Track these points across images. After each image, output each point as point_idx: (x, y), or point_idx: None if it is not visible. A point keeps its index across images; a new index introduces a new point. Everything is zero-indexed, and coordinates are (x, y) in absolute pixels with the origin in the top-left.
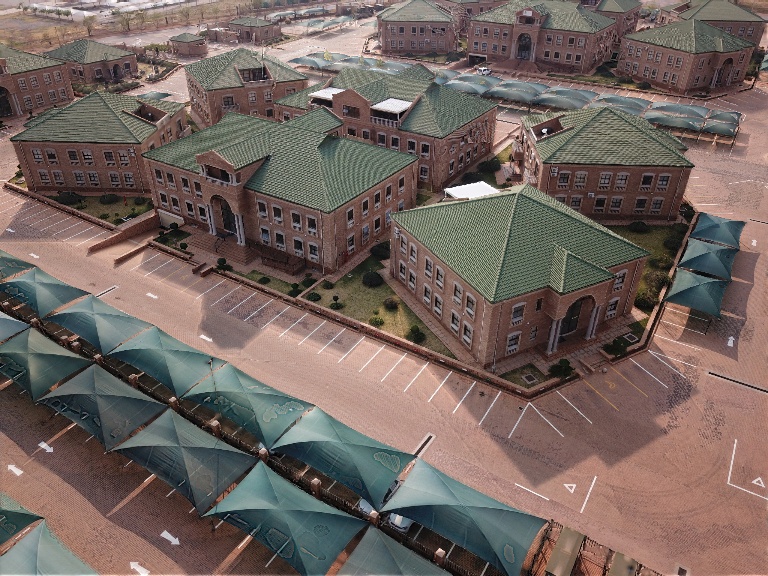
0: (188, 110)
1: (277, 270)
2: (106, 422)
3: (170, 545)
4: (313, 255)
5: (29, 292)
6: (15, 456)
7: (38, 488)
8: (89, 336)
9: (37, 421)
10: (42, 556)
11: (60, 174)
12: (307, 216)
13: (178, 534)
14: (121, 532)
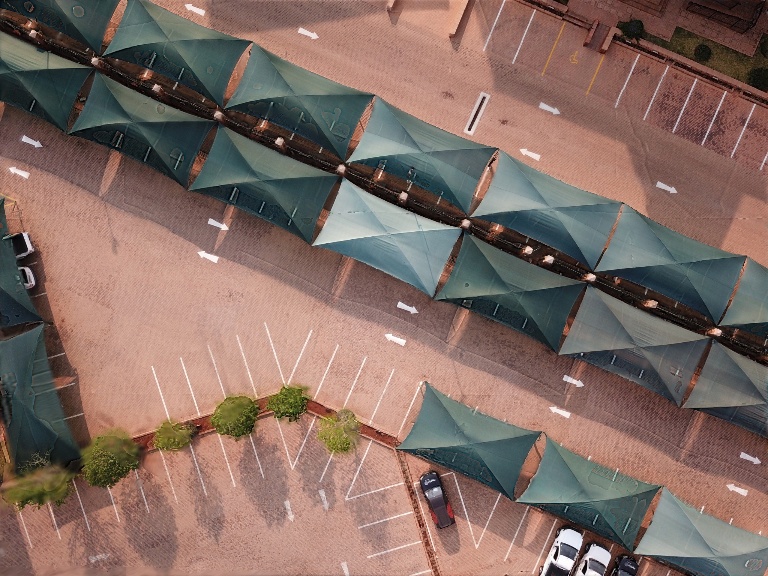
0: None
1: (713, 22)
2: (668, 380)
3: (753, 465)
4: None
5: (427, 174)
6: (549, 397)
7: (598, 429)
8: (562, 246)
9: (541, 350)
10: (705, 534)
11: None
12: None
13: (756, 454)
14: (703, 460)
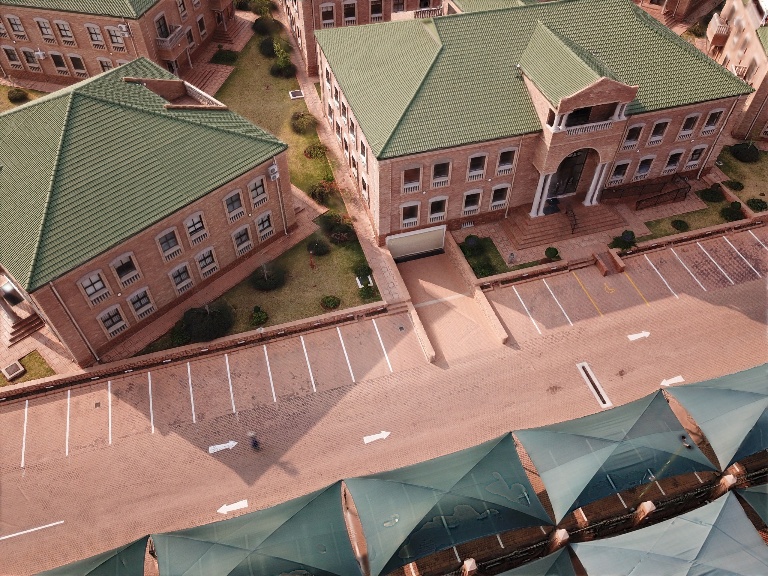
0: (2, 82)
1: (660, 206)
2: None
3: None
4: (691, 162)
5: (646, 460)
6: None
7: None
8: None
9: None
10: None
11: (140, 295)
12: (711, 112)
13: None
14: None
